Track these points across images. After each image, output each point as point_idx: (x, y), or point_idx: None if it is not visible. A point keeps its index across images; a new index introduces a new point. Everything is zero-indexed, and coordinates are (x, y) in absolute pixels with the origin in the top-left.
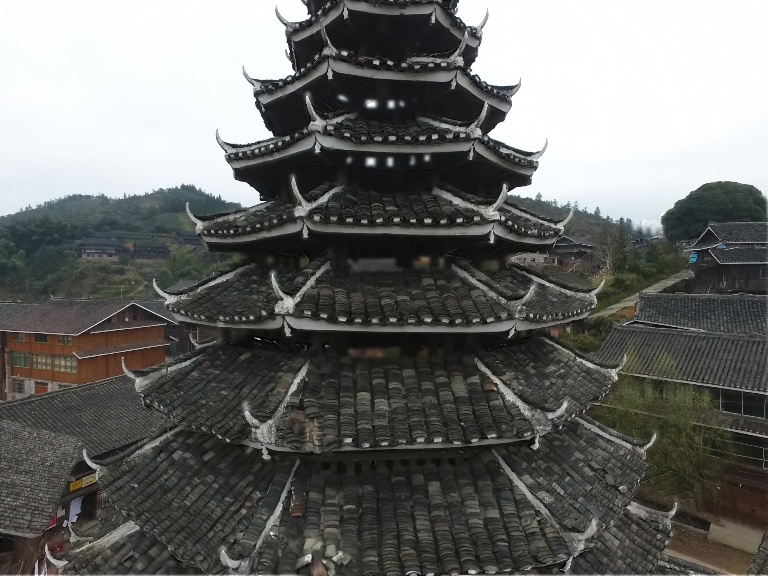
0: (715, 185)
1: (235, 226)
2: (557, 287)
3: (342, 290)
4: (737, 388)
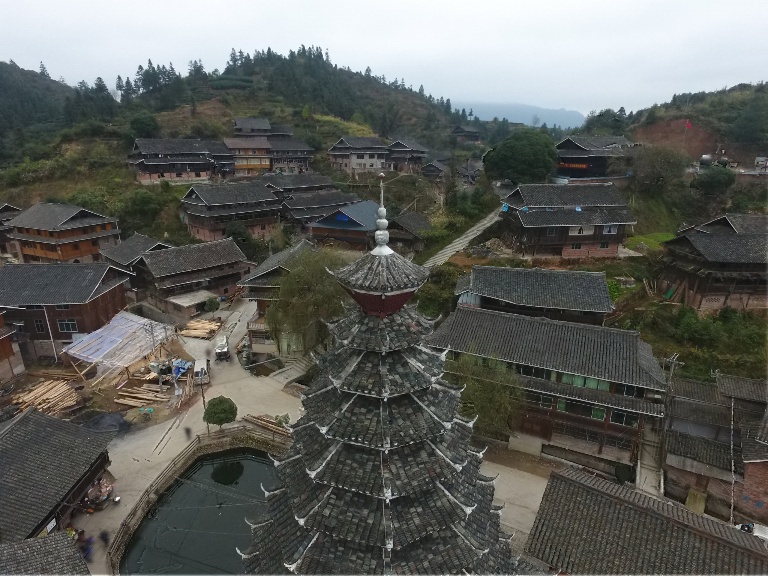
0: (524, 135)
1: (332, 528)
2: (478, 481)
3: (405, 564)
4: (532, 365)
